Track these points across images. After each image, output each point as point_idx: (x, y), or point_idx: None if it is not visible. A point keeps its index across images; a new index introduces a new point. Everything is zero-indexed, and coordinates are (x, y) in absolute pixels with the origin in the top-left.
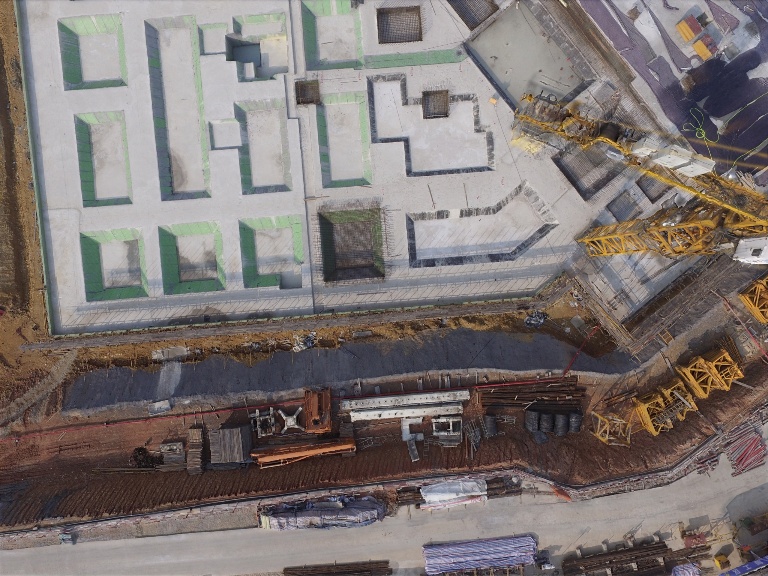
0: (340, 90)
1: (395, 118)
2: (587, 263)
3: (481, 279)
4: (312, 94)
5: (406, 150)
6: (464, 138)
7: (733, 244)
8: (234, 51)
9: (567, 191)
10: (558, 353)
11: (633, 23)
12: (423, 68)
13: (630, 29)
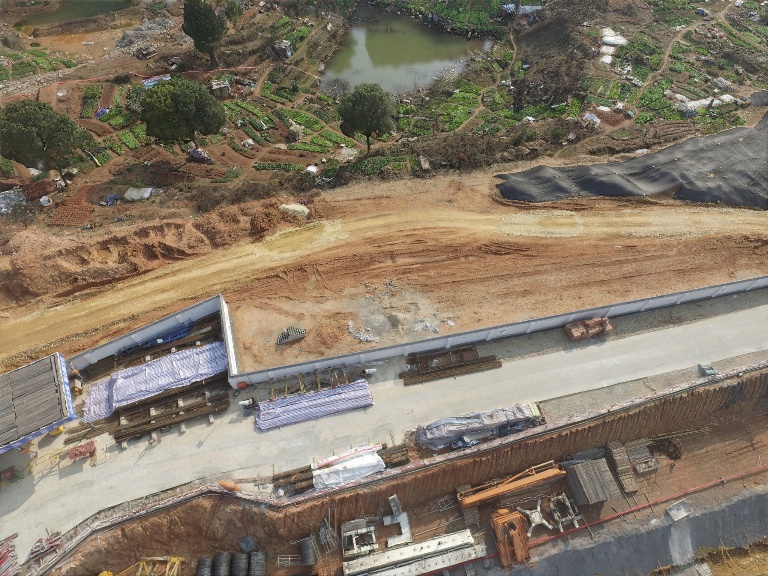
0: None
1: None
2: None
3: None
4: None
5: None
6: None
7: None
8: None
9: None
10: None
11: None
12: None
13: None
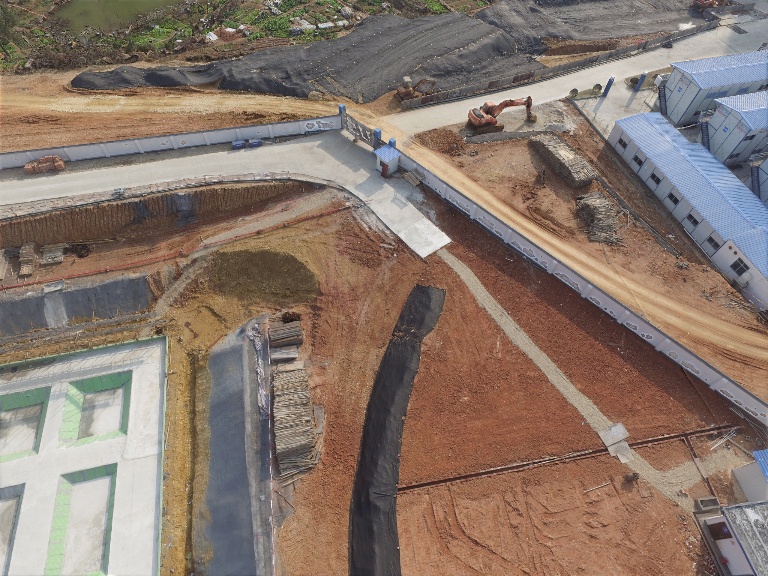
0: None
1: None
2: None
3: None
4: None
5: None
6: None
7: None
8: None
9: None
10: None
11: None
12: None
13: None
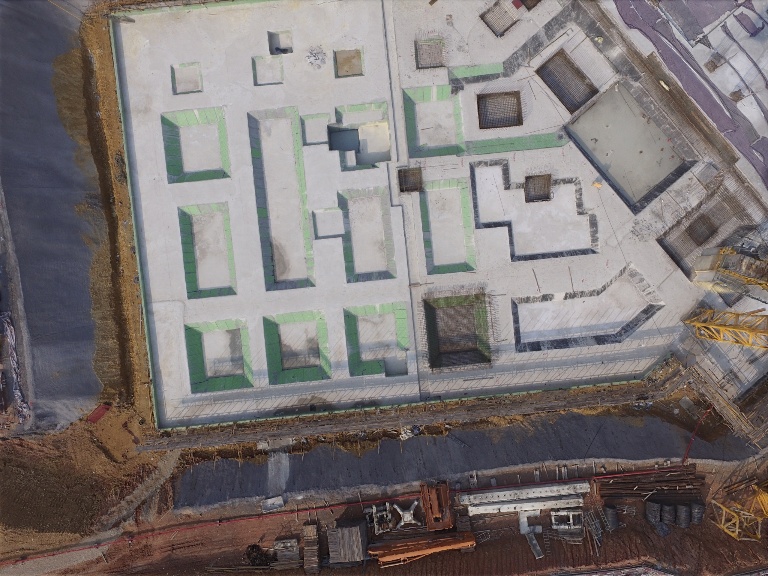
0: (443, 177)
1: (497, 202)
2: (694, 344)
3: (588, 362)
4: (413, 180)
5: (509, 234)
6: (567, 221)
7: None
8: (331, 137)
9: (673, 272)
10: (672, 438)
11: (736, 105)
12: (526, 153)
13: (733, 111)
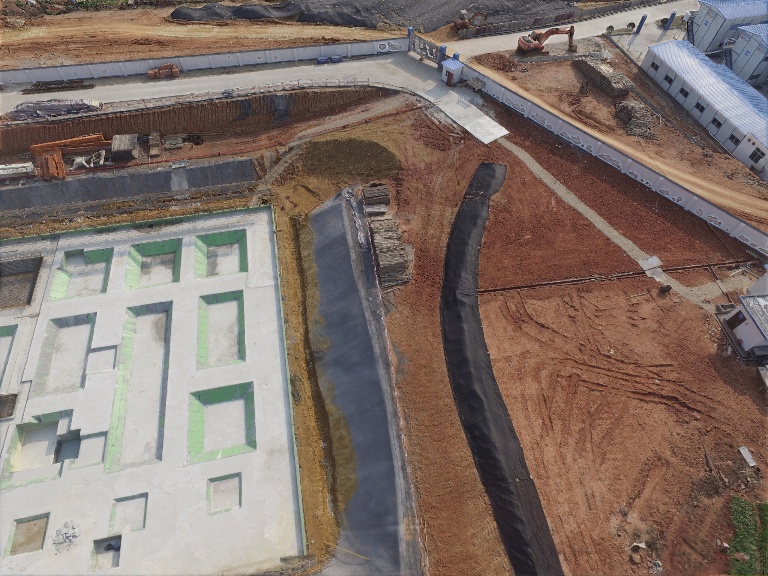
0: None
1: None
2: None
3: None
4: (4, 413)
5: None
6: None
7: None
8: None
9: None
10: None
11: None
12: None
13: None
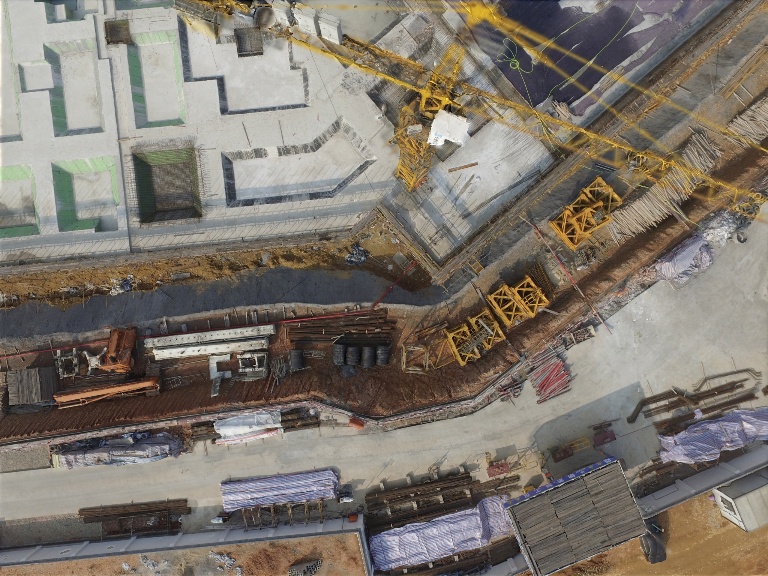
0: (151, 29)
1: (209, 57)
2: (407, 198)
3: (300, 217)
4: (126, 35)
5: (220, 88)
6: (280, 76)
7: (421, 126)
8: None
9: (384, 126)
10: (373, 288)
11: None
12: None
13: None
